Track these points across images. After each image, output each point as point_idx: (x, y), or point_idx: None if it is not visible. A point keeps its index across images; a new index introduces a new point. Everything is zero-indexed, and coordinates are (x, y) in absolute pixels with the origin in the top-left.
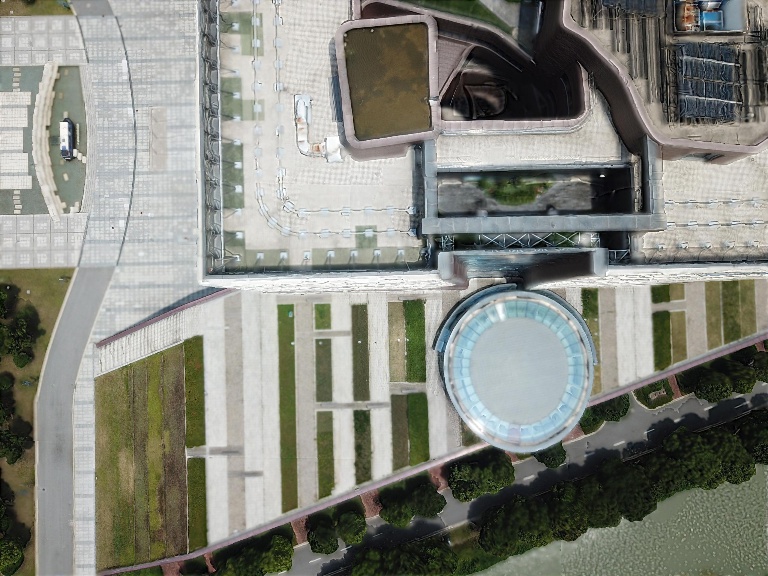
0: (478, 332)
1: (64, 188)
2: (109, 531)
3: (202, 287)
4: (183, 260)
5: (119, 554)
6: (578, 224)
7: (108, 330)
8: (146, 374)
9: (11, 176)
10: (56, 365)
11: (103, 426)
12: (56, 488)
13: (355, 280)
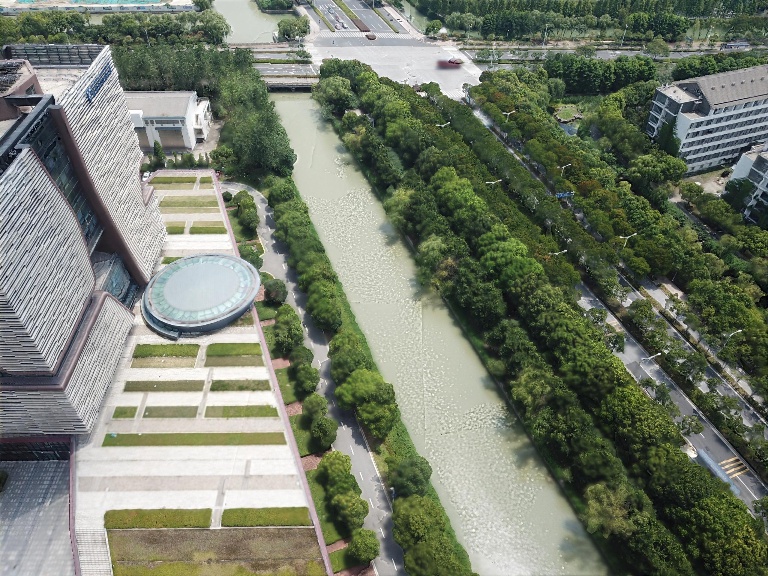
0: (167, 307)
1: None
2: None
3: None
4: (36, 570)
5: None
6: (32, 114)
7: None
8: None
9: None
10: None
11: None
12: None
13: (8, 173)
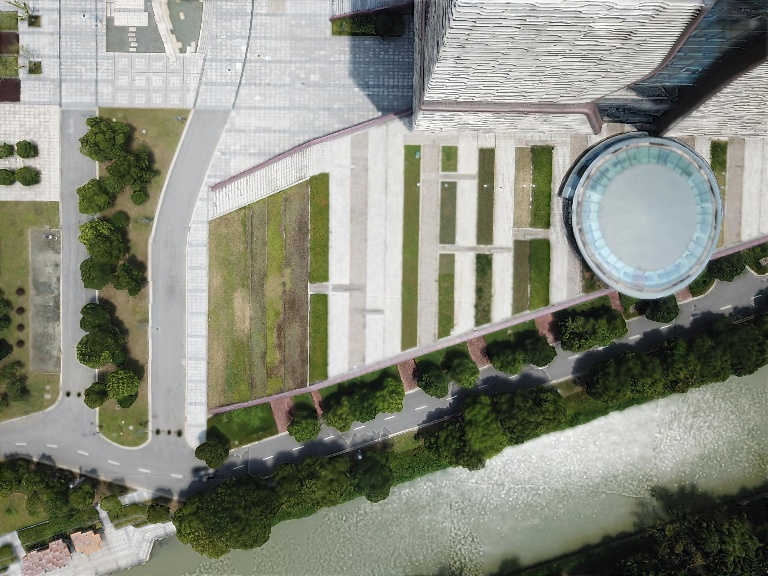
0: (609, 177)
1: (180, 27)
2: (222, 370)
3: (318, 134)
4: (300, 106)
5: (233, 392)
6: None
7: (223, 174)
8: (266, 214)
9: (127, 12)
10: (171, 207)
11: (217, 268)
12: (169, 328)
13: (617, 1)
